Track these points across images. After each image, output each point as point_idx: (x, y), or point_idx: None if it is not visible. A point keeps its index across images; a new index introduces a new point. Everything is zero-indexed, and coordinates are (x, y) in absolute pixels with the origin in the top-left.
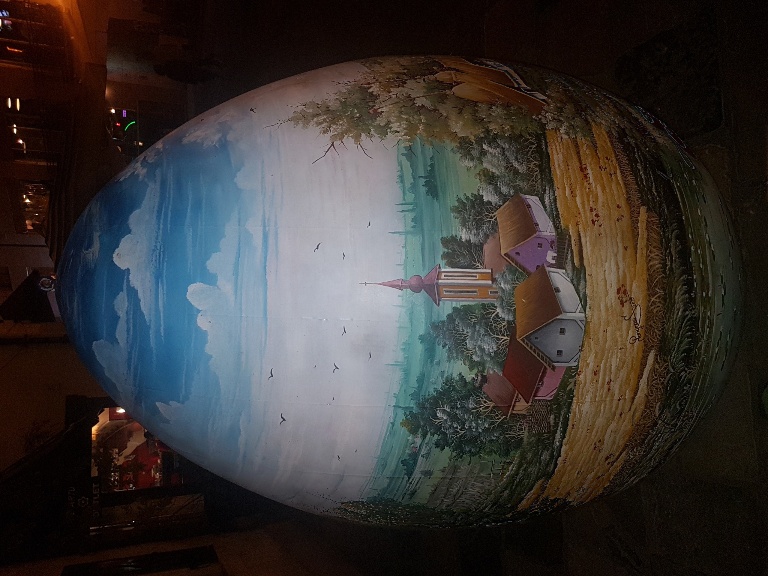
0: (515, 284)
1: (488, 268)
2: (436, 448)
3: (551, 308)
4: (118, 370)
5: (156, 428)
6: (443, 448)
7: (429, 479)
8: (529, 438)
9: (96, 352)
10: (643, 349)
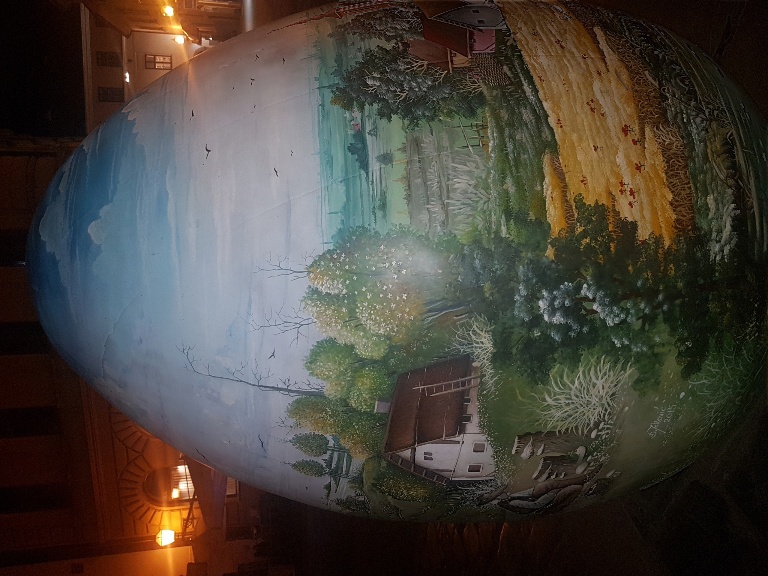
0: None
1: None
2: (382, 120)
3: (456, 4)
4: (57, 224)
5: (92, 290)
6: (390, 118)
7: (392, 168)
8: (490, 92)
9: (41, 231)
10: None
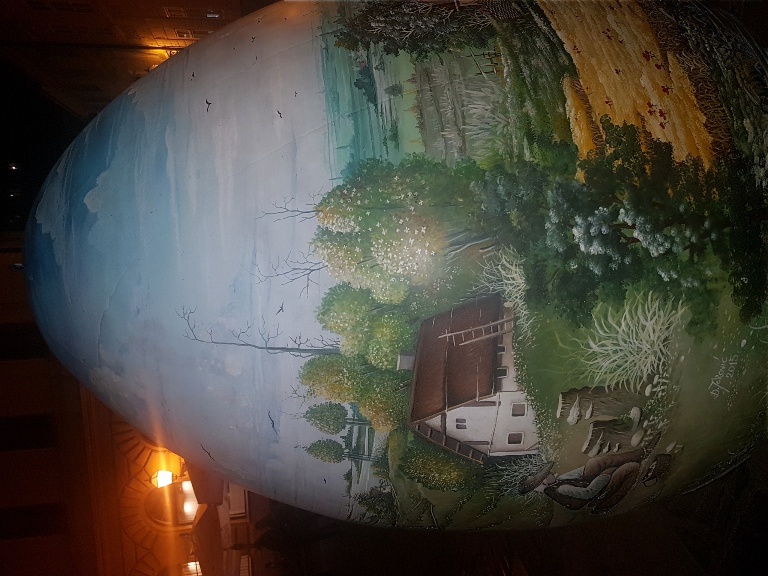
0: None
1: None
2: (388, 55)
3: None
4: (53, 203)
5: (87, 263)
6: (397, 53)
7: (402, 99)
8: (500, 24)
9: None
10: None
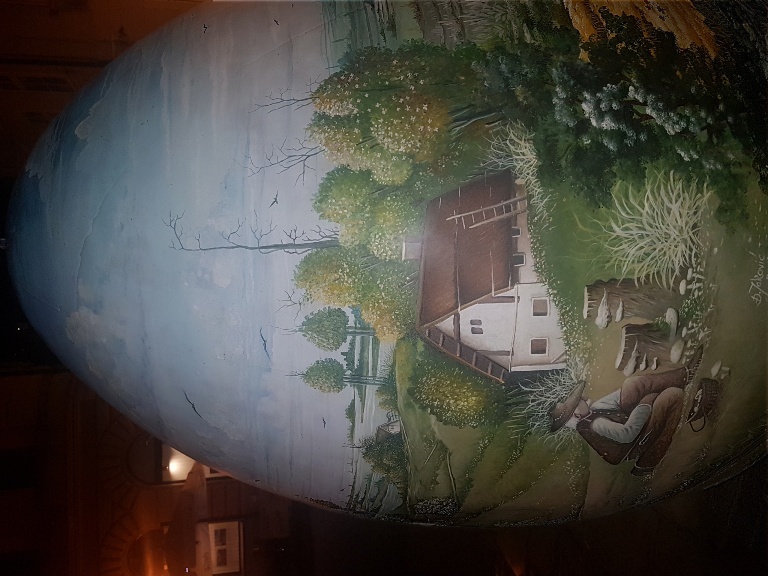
0: None
1: None
2: None
3: None
4: (43, 147)
5: (72, 190)
6: None
7: None
8: None
9: None
10: None
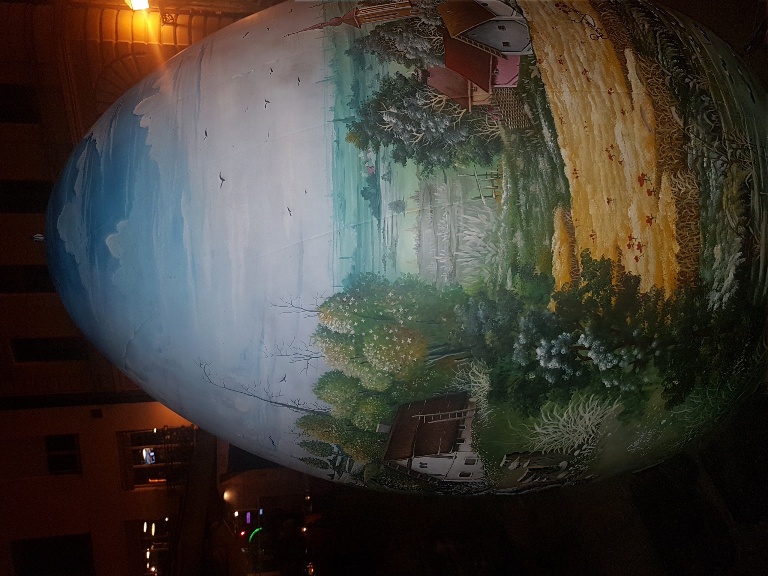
0: (436, 4)
1: (405, 1)
2: (396, 163)
3: (482, 15)
4: (75, 228)
5: (112, 299)
6: (405, 161)
7: (404, 217)
8: (508, 136)
9: (59, 229)
10: (613, 46)
